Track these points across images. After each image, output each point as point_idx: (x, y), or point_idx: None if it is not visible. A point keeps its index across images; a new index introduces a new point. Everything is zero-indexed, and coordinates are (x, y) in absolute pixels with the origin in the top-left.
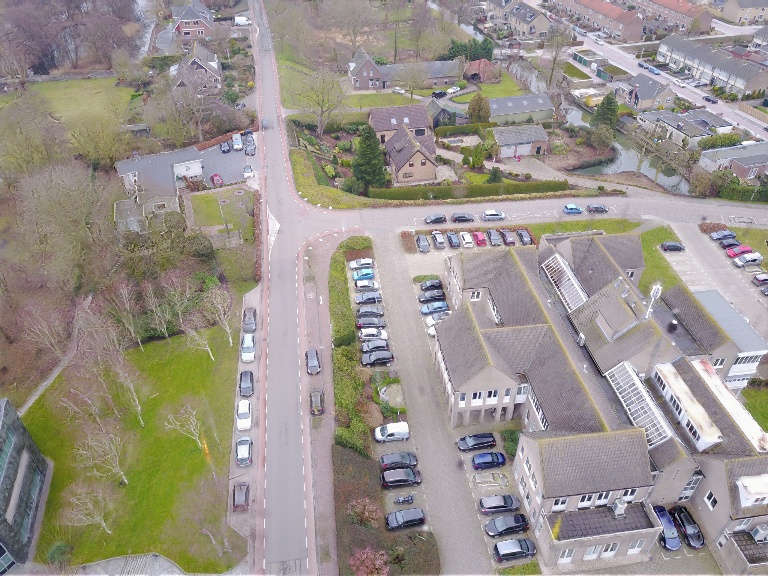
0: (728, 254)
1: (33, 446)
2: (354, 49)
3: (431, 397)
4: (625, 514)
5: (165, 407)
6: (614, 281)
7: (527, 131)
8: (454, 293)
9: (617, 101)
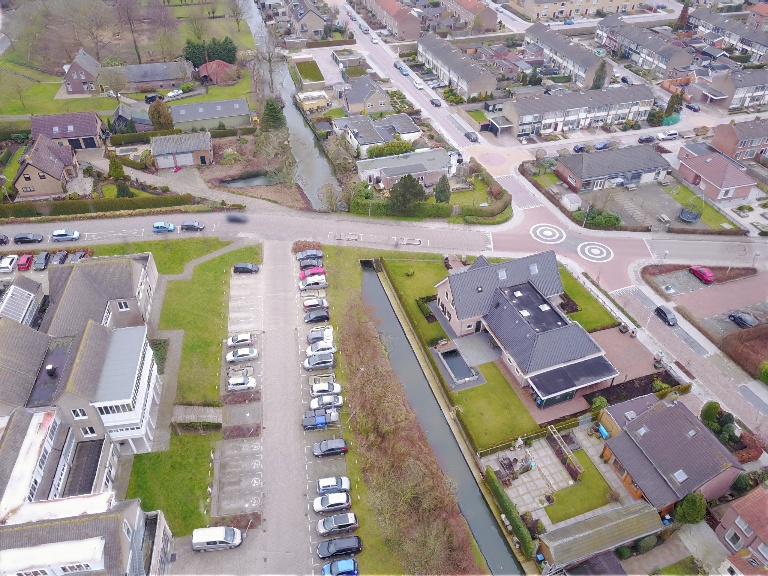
0: (299, 276)
1: None
2: (96, 49)
3: None
4: None
5: None
6: None
7: (190, 139)
8: None
9: (278, 107)
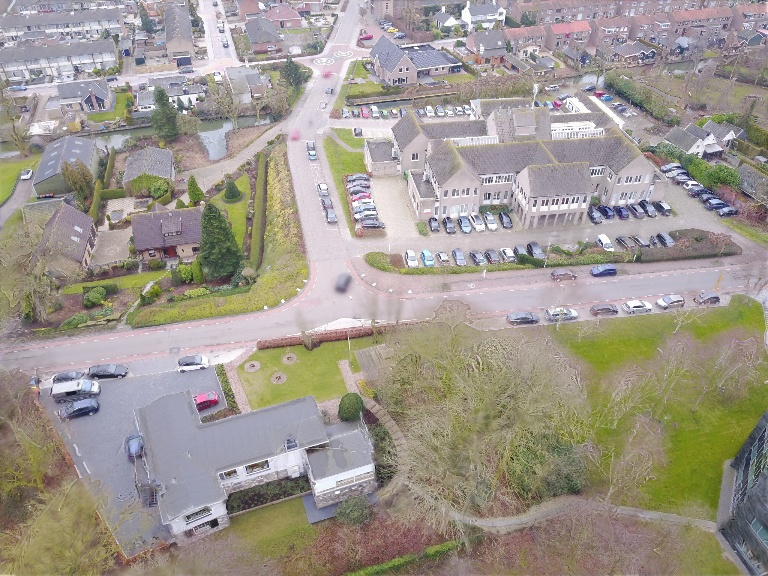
0: (366, 117)
1: None
2: None
3: (560, 232)
4: None
5: None
6: (495, 114)
7: (154, 156)
8: (453, 209)
9: None
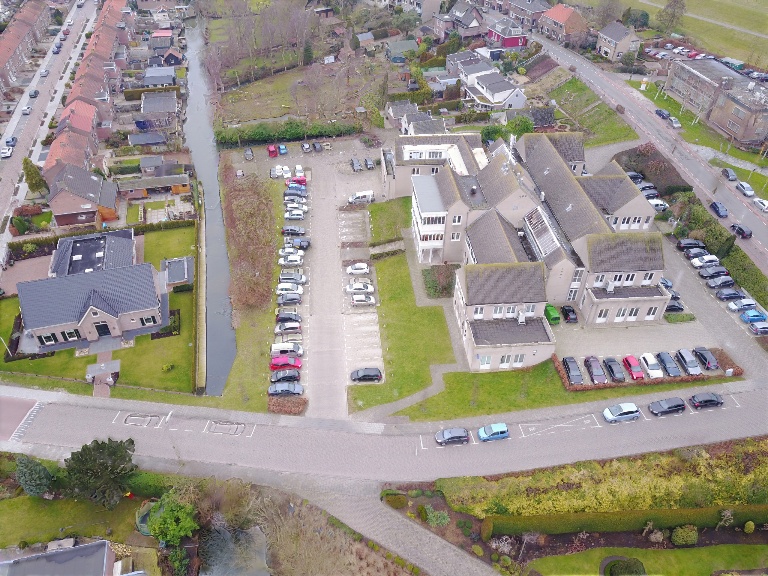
0: None
1: None
2: None
3: None
4: None
5: None
6: None
7: None
8: None
9: None
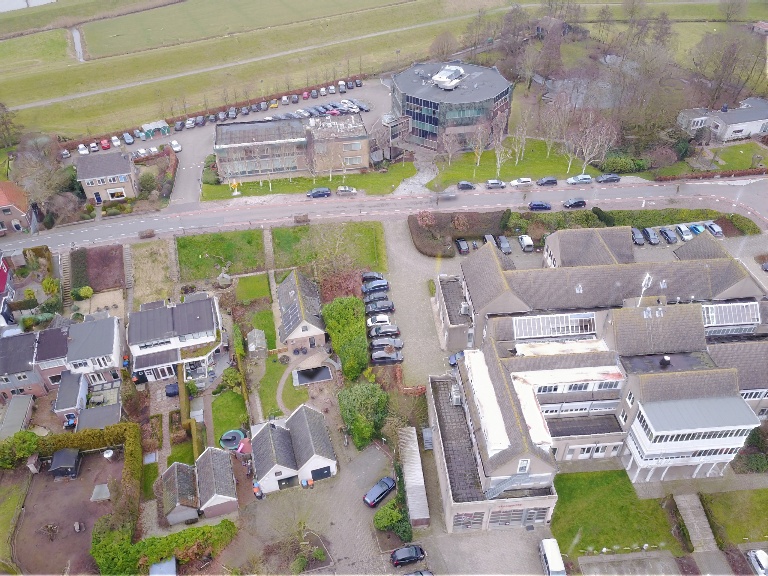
0: None
1: (488, 131)
2: None
3: None
4: (462, 316)
5: (530, 168)
6: None
7: None
8: None
9: None
